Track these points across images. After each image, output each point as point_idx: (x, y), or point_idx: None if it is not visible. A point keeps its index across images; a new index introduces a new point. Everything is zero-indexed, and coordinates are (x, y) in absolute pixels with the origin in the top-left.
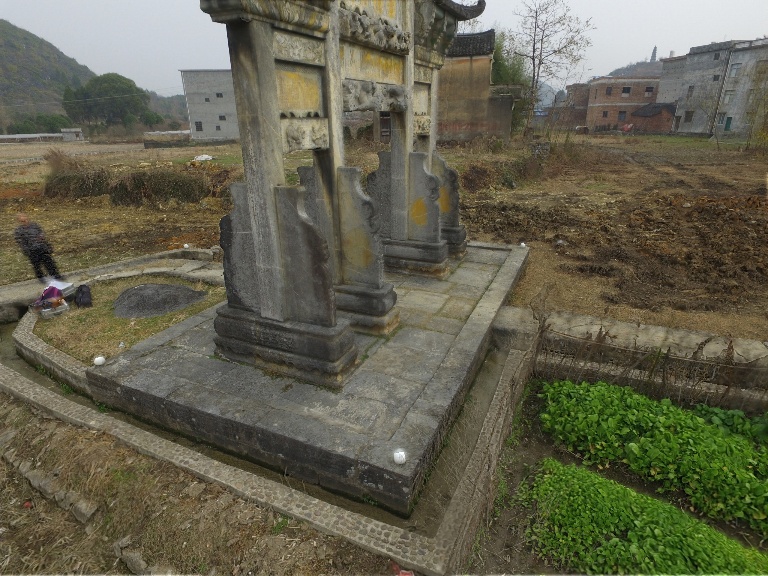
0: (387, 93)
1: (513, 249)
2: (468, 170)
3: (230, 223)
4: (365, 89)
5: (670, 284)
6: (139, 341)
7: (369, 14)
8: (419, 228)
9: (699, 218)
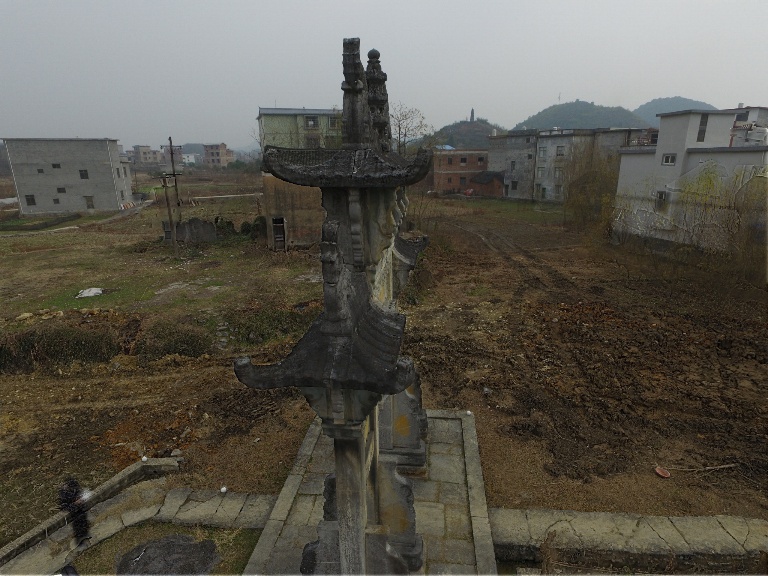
0: None
1: (462, 418)
2: None
3: (314, 556)
4: None
5: (582, 438)
6: None
7: None
8: (403, 438)
9: (570, 339)
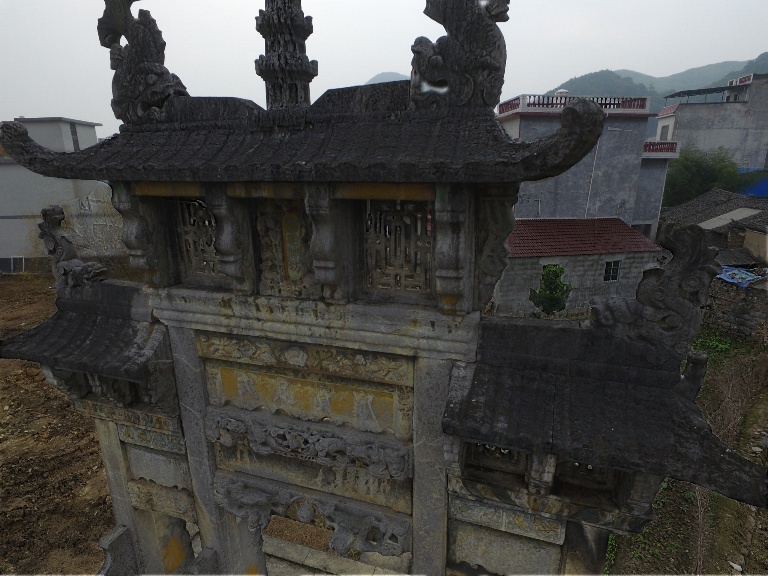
0: None
1: None
2: None
3: None
4: None
5: None
6: None
7: None
8: None
9: None
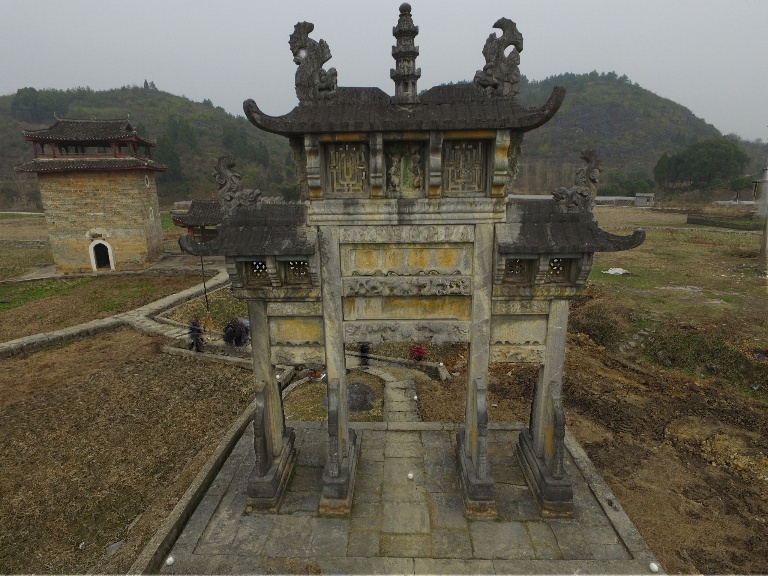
0: (426, 328)
1: (634, 560)
2: None
3: None
4: (367, 330)
5: None
6: (293, 420)
7: (400, 271)
8: None
9: None
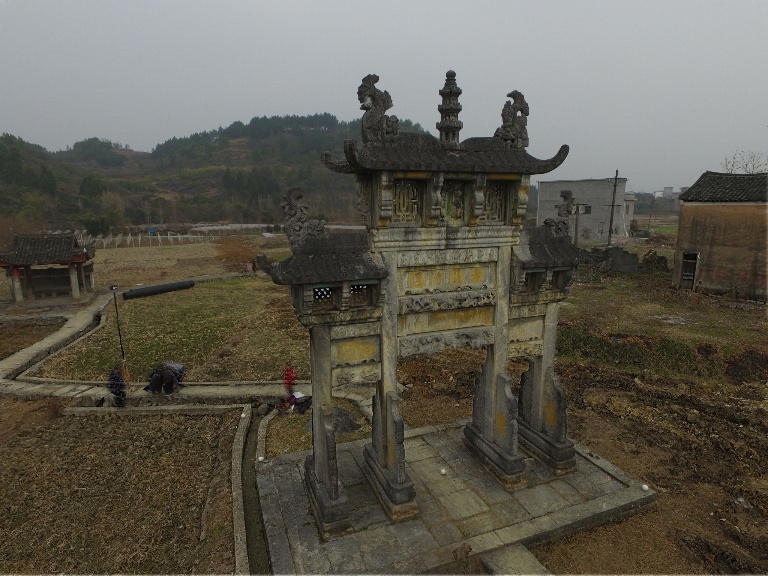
0: (463, 335)
1: (630, 487)
2: (740, 354)
3: None
4: (421, 342)
5: None
6: (294, 451)
7: (443, 289)
8: (501, 437)
9: None
